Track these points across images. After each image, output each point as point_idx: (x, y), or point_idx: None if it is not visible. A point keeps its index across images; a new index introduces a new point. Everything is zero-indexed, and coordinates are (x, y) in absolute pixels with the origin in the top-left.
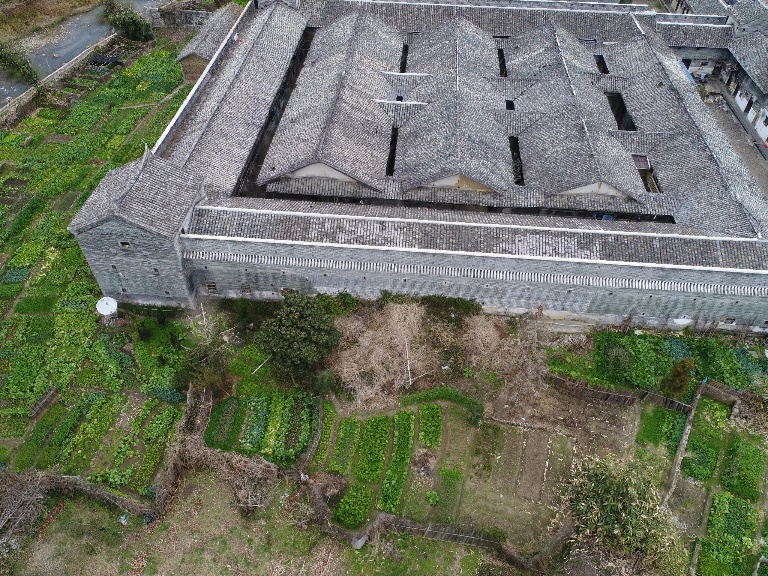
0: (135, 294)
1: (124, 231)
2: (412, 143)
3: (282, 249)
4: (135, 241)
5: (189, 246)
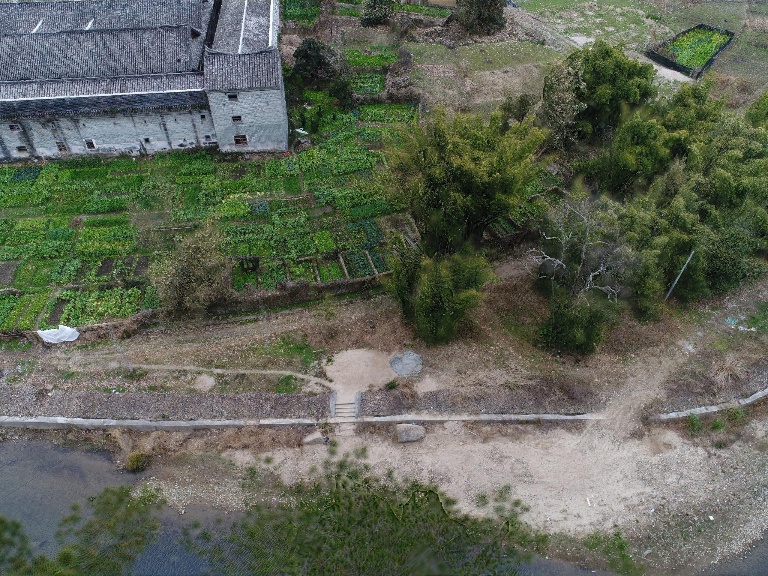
0: None
1: None
2: None
3: None
4: None
5: None
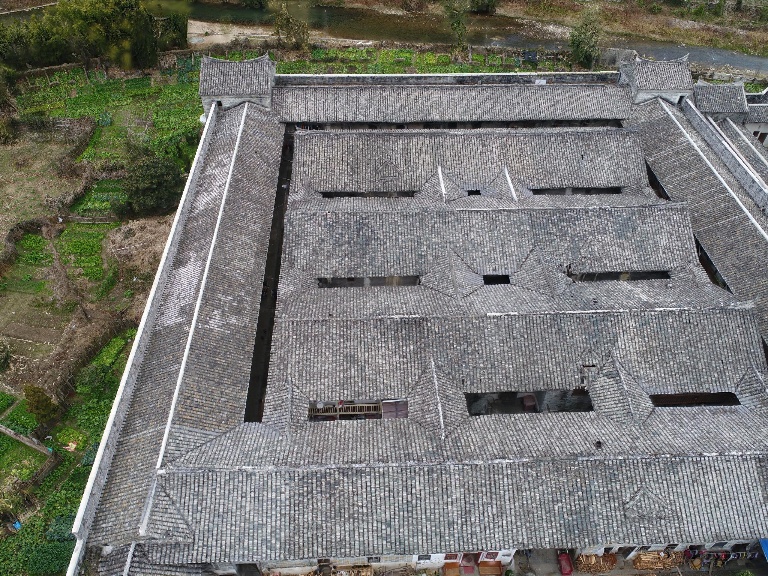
0: None
1: None
2: (373, 201)
3: None
4: None
5: None
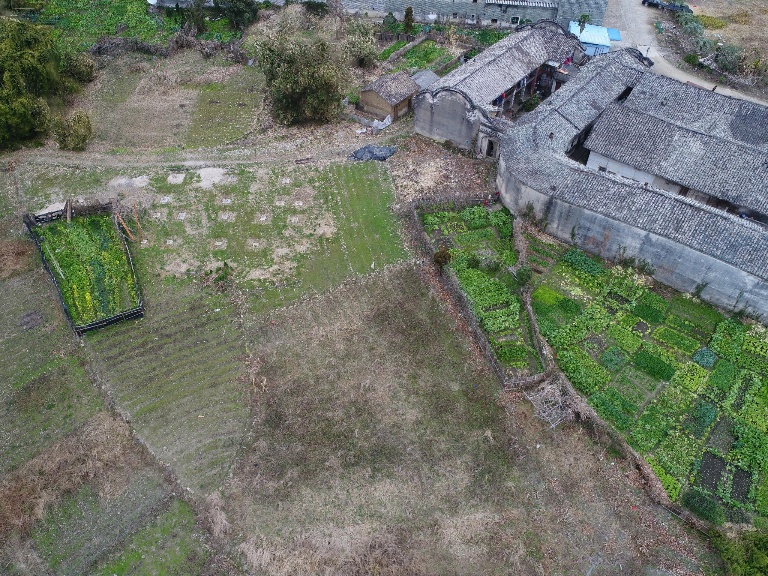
0: None
1: None
2: None
3: None
4: None
5: None
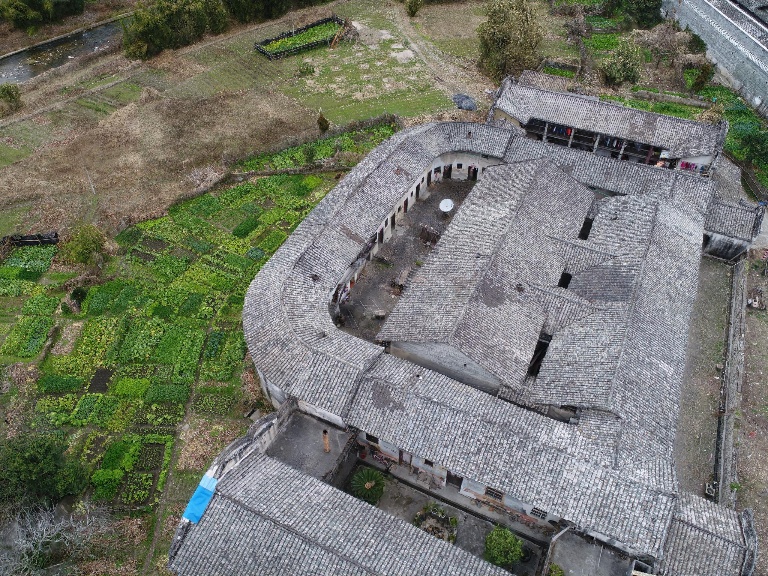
0: None
1: None
2: None
3: None
4: None
5: None
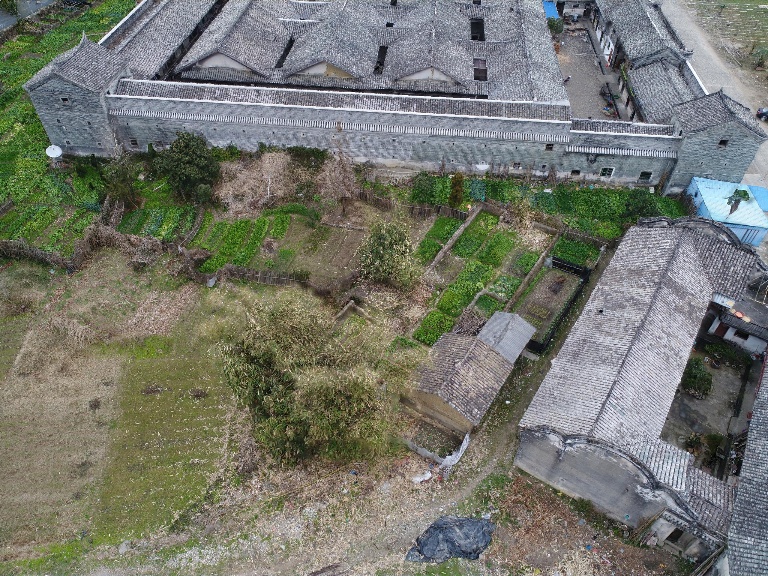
0: (76, 146)
1: (63, 88)
2: (301, 48)
3: (180, 106)
4: (72, 97)
5: (113, 105)
